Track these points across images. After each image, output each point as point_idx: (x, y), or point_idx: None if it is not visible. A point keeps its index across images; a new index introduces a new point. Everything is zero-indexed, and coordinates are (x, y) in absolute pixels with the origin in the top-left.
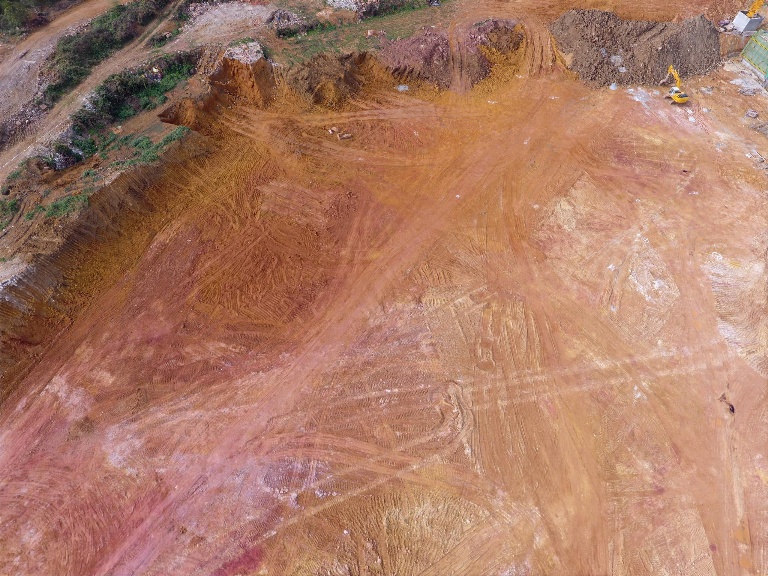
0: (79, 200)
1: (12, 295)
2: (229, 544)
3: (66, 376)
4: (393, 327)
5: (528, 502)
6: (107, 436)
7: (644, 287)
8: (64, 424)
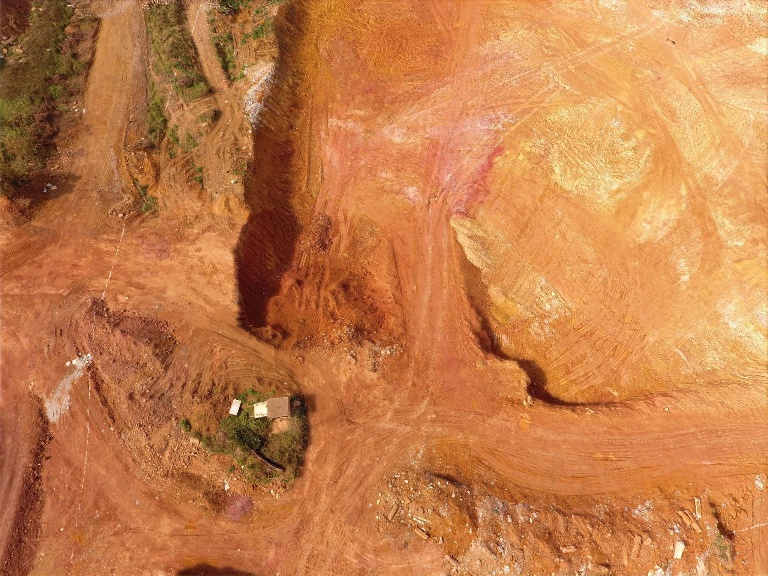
0: (268, 25)
1: (276, 80)
2: (485, 149)
3: (335, 117)
4: (494, 53)
5: (607, 97)
6: (384, 132)
7: (608, 5)
8: (356, 135)
